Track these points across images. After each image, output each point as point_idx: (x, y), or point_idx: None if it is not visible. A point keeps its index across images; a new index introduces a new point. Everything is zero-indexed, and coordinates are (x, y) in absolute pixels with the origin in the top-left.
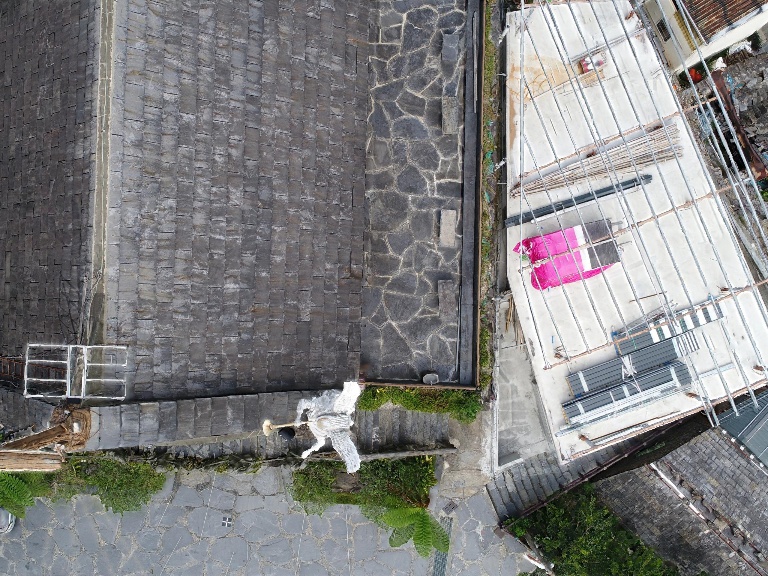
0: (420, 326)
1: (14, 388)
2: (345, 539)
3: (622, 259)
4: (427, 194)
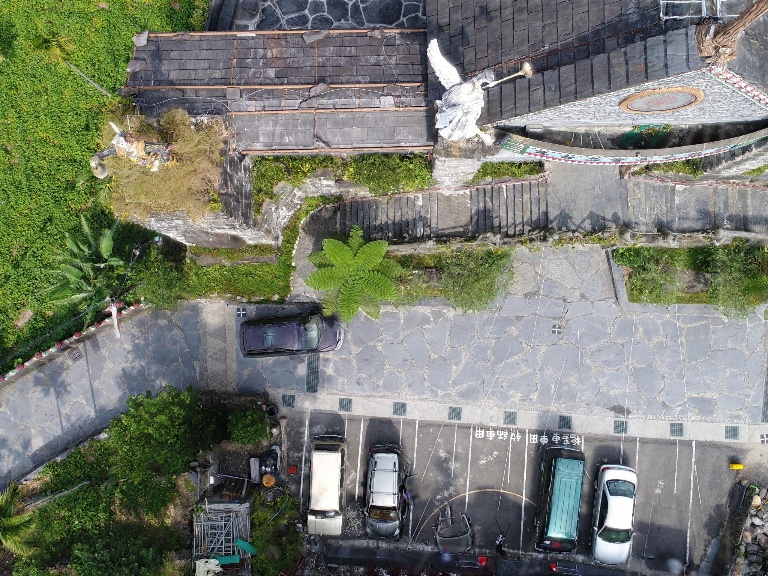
0: None
1: None
2: (677, 341)
3: None
4: None
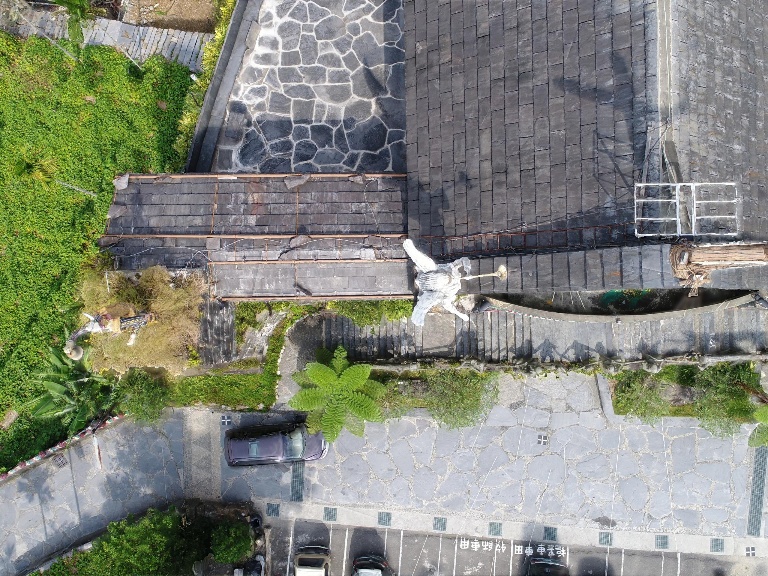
0: None
1: None
2: (663, 452)
3: None
4: None
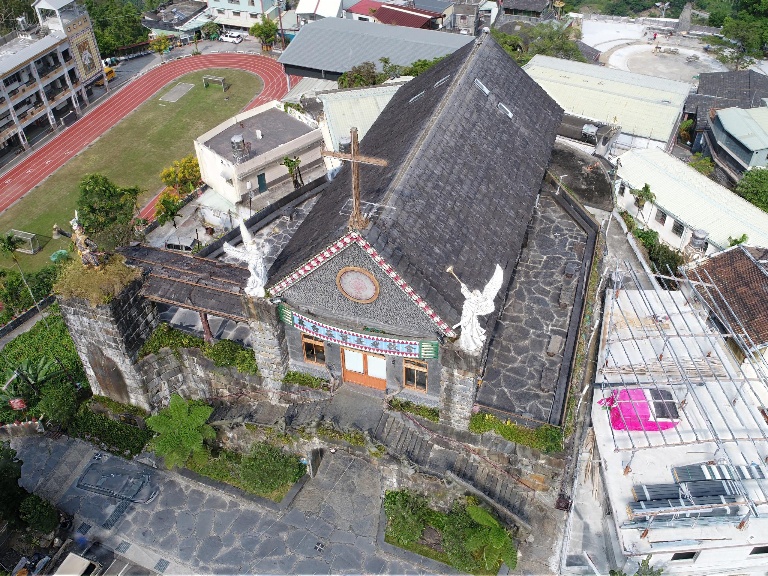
0: (525, 396)
1: None
2: None
3: (681, 425)
4: (543, 332)
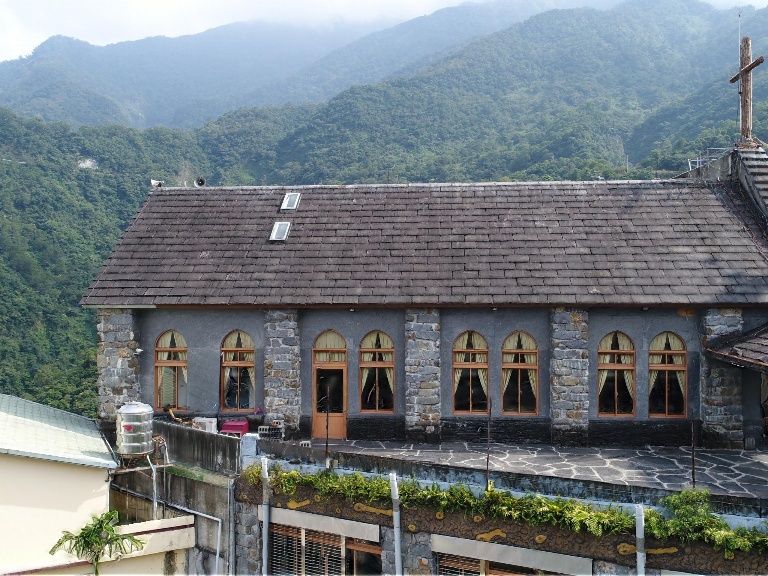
0: None
1: (767, 216)
2: None
3: None
4: None
